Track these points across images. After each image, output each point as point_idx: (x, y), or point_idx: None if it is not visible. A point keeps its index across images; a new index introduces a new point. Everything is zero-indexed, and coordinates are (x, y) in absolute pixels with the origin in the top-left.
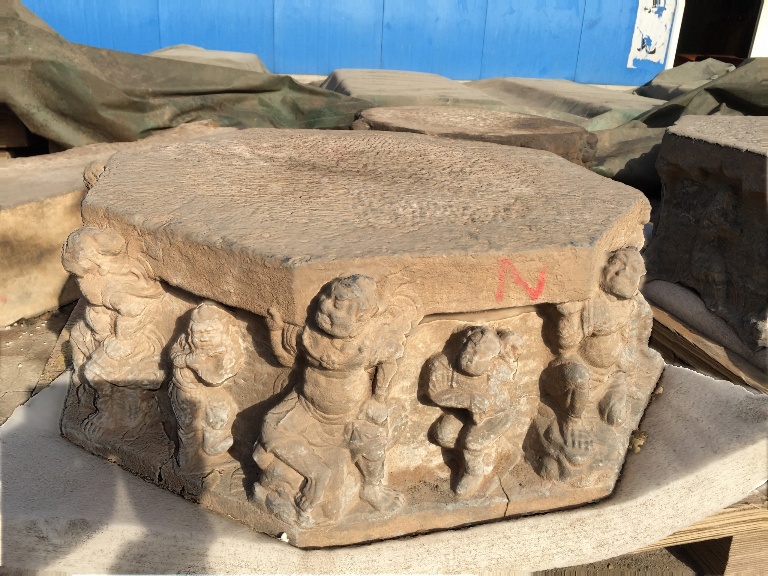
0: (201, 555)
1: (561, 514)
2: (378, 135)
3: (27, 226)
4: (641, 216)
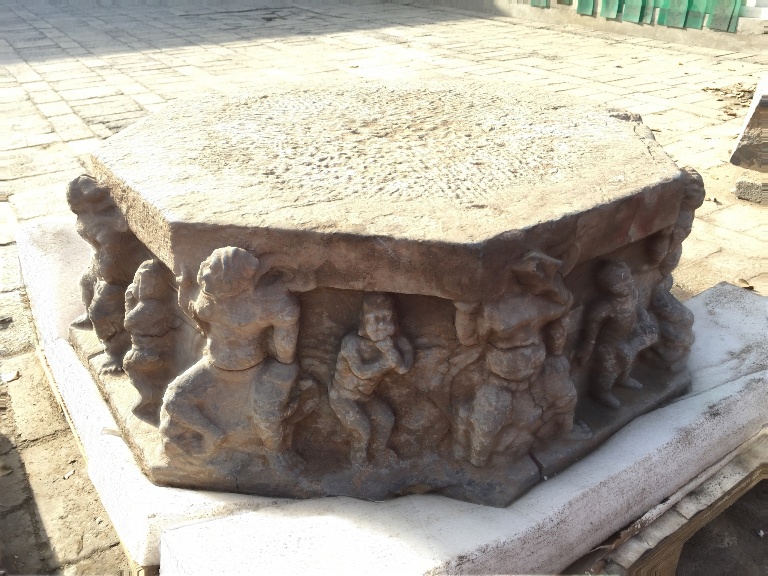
0: None
1: None
2: (502, 215)
3: None
4: None
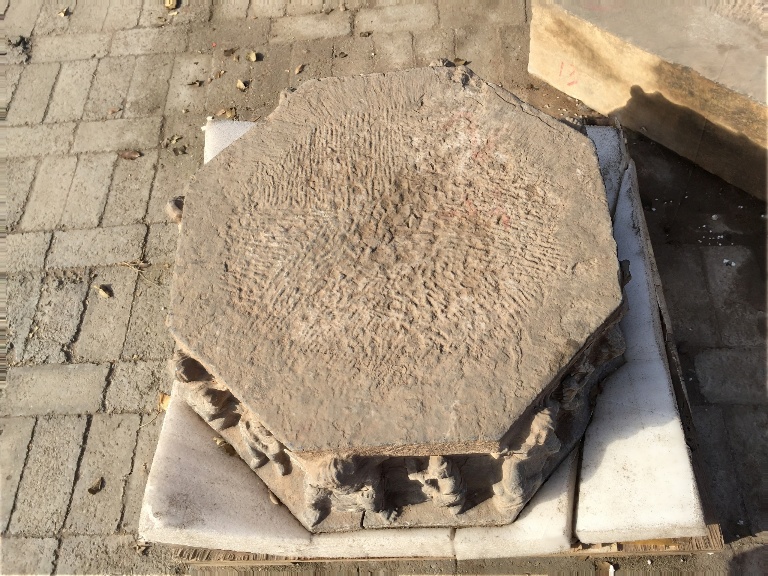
0: None
1: None
2: (593, 263)
3: (608, 50)
4: None
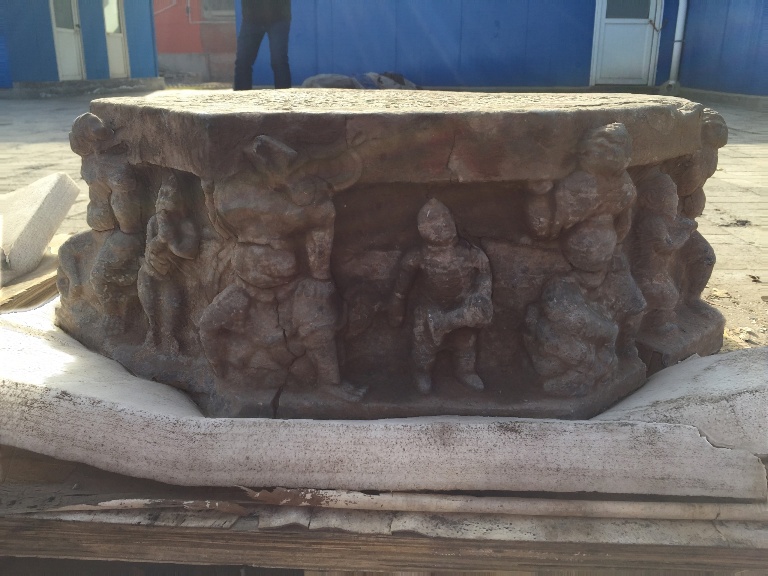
0: None
1: None
2: None
3: None
4: None
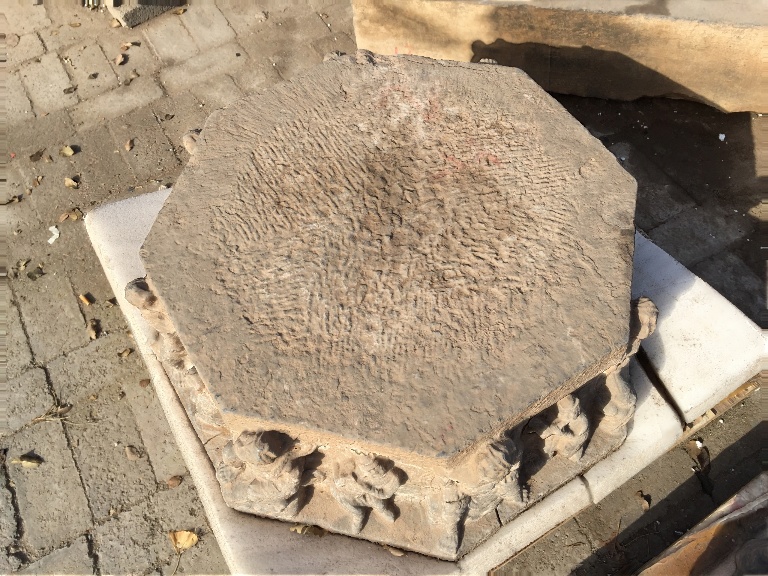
0: (127, 313)
1: (206, 478)
2: (592, 163)
3: (442, 17)
4: (475, 471)
